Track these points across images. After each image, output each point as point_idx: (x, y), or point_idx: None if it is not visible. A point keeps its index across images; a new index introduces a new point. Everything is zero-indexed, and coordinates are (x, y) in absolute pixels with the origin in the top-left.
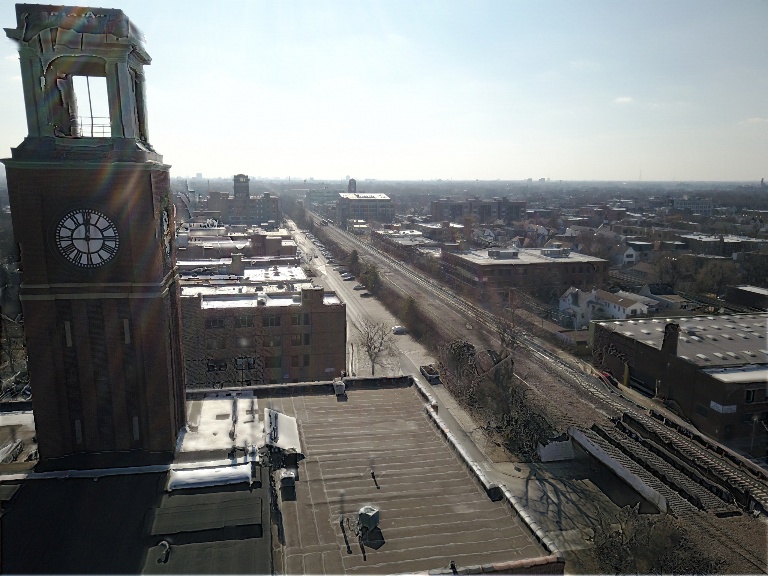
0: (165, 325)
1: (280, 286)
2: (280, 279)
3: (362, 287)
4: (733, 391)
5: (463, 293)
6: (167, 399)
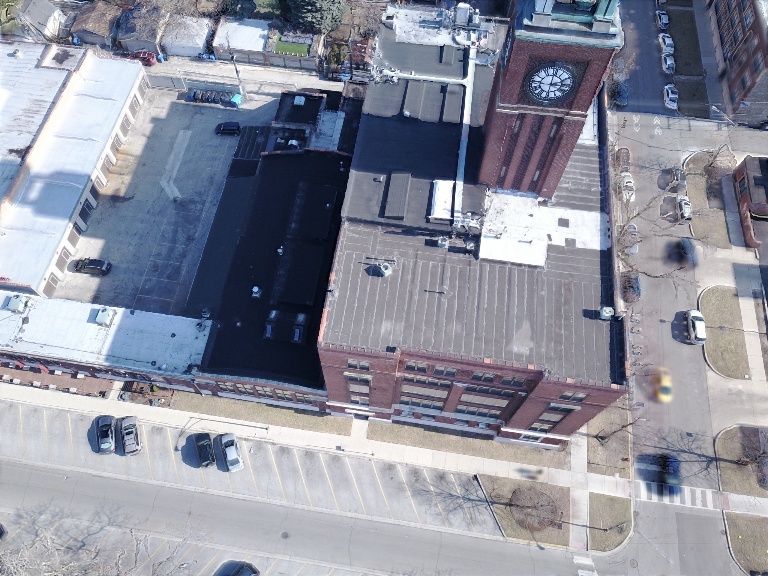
0: (494, 126)
1: None
2: None
3: None
4: None
5: None
6: None
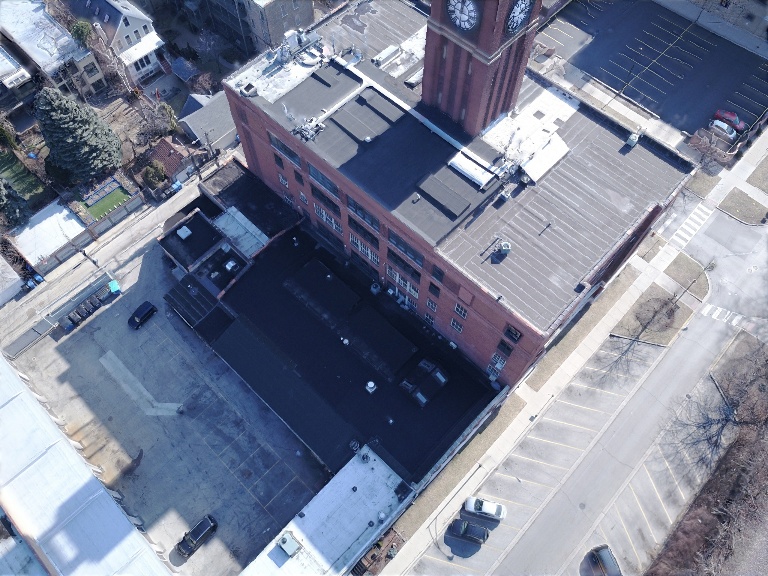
0: (486, 79)
1: None
2: None
3: None
4: None
5: None
6: (477, 114)
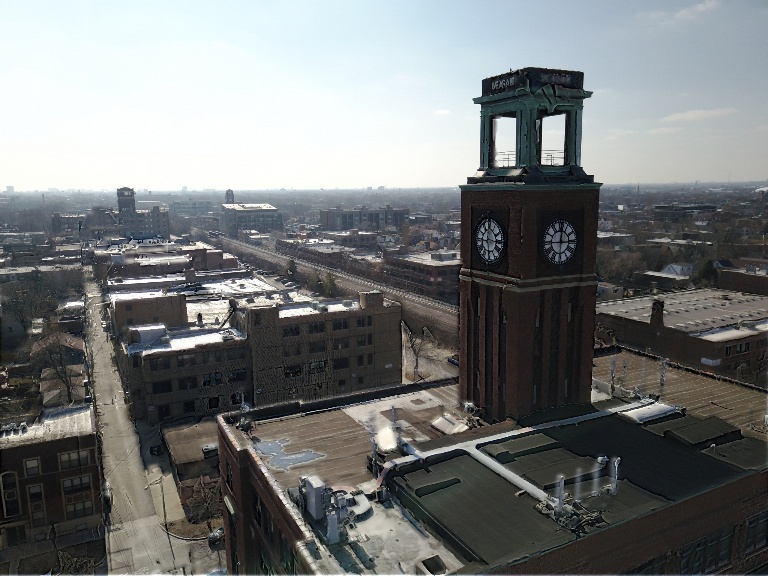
0: None
1: (268, 297)
2: (252, 291)
3: (317, 294)
4: (719, 348)
5: (428, 293)
6: None
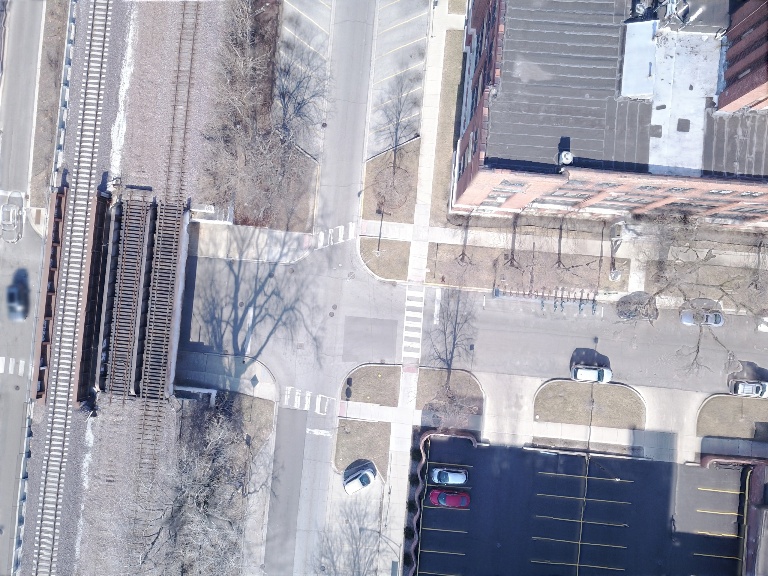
0: None
1: None
2: None
3: None
4: None
5: None
6: None
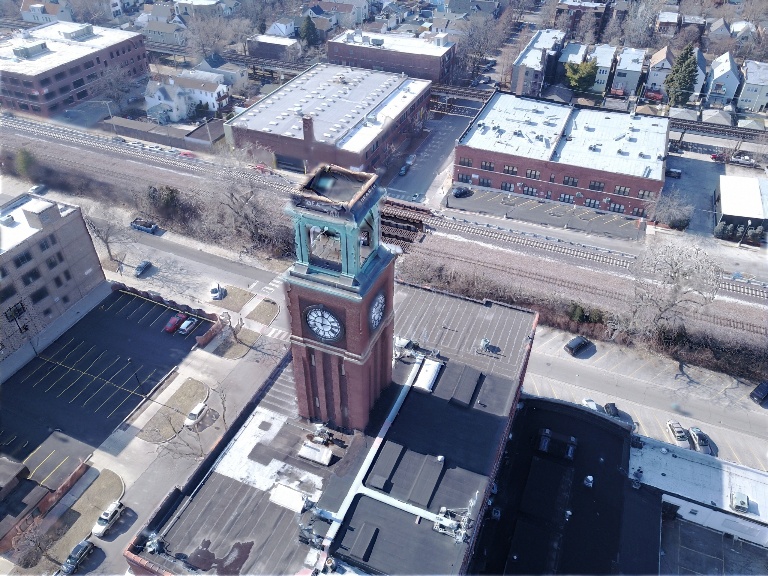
0: None
1: None
2: None
3: None
4: (362, 156)
5: (44, 117)
6: None
